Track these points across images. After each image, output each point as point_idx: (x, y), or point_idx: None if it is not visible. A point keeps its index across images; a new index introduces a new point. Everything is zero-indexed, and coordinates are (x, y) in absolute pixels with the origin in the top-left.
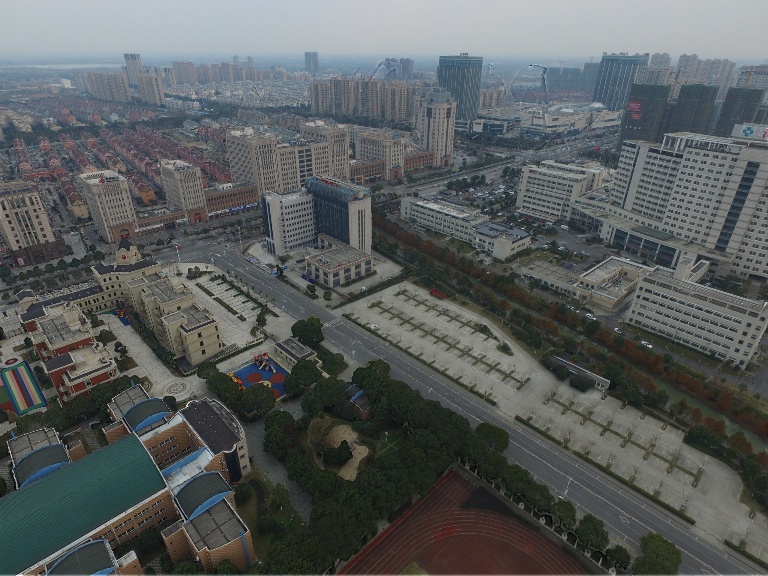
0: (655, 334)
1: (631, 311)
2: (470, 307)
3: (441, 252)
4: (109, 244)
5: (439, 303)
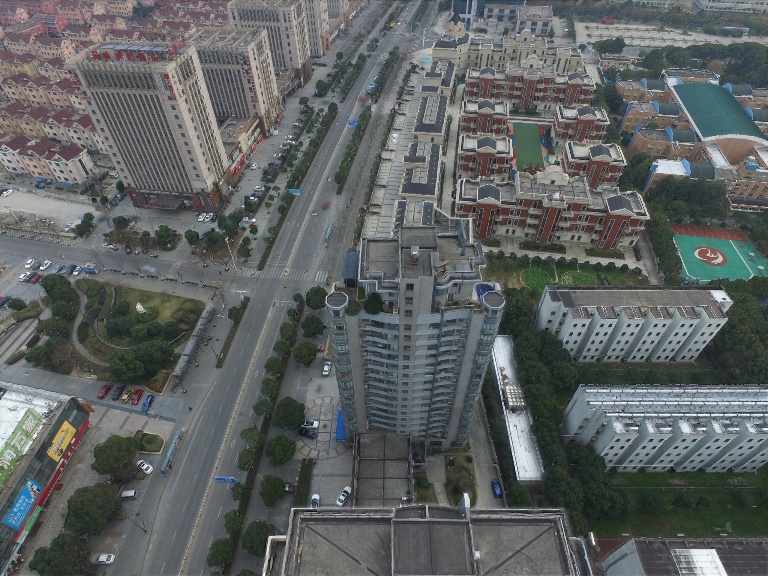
0: (722, 11)
1: (708, 1)
2: (633, 23)
3: (562, 2)
4: (321, 57)
5: (616, 26)
